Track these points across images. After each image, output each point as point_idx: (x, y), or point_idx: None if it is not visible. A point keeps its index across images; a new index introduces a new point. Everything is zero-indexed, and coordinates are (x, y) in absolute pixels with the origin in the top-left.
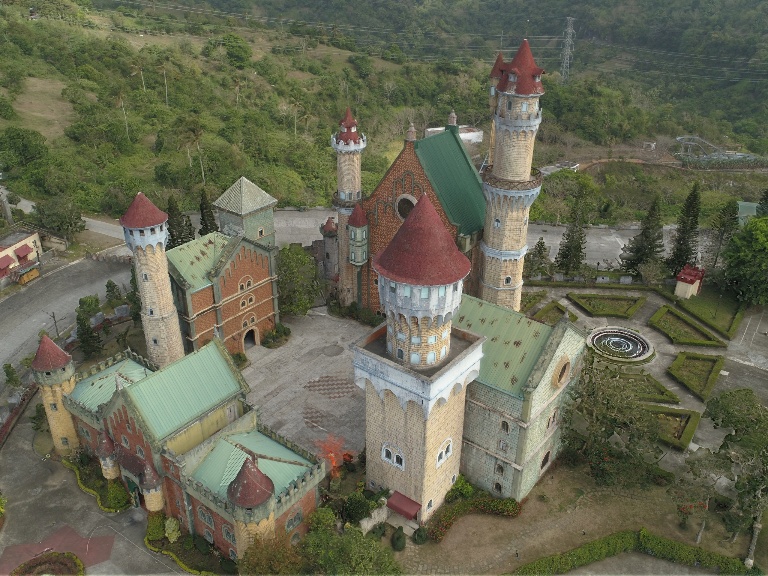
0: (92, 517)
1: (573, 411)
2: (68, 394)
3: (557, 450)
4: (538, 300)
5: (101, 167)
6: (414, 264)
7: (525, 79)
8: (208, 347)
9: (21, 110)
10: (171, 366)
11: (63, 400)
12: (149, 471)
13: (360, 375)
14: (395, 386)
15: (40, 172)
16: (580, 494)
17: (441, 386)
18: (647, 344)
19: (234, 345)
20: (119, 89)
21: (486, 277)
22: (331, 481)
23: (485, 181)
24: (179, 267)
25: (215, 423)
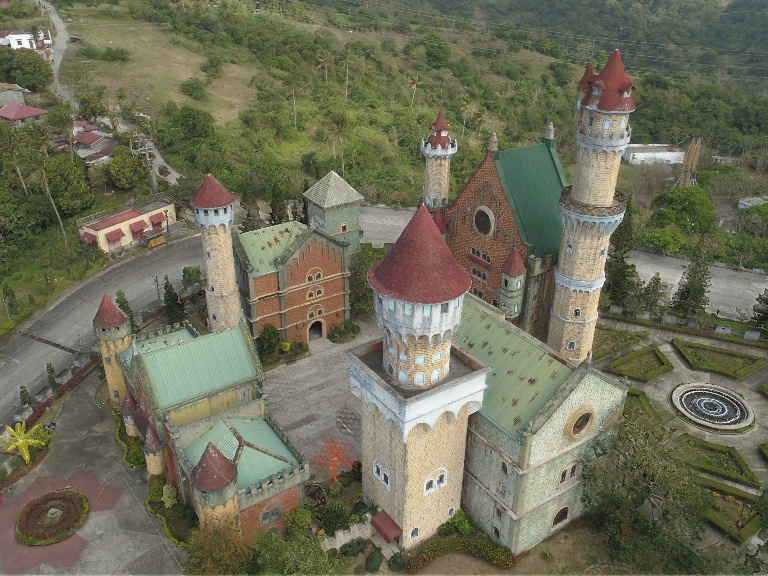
0: (115, 467)
1: (608, 469)
2: (121, 351)
3: (582, 508)
4: (635, 341)
5: (260, 150)
6: (401, 277)
7: (610, 93)
8: (233, 330)
9: (212, 93)
10: (191, 341)
11: (116, 356)
12: (150, 436)
13: (354, 383)
14: (379, 401)
15: (194, 149)
16: (592, 563)
17: (422, 410)
18: (747, 412)
19: (298, 333)
20: (292, 79)
21: (555, 305)
22: (331, 485)
23: (560, 201)
24: (249, 250)
25: (226, 403)
